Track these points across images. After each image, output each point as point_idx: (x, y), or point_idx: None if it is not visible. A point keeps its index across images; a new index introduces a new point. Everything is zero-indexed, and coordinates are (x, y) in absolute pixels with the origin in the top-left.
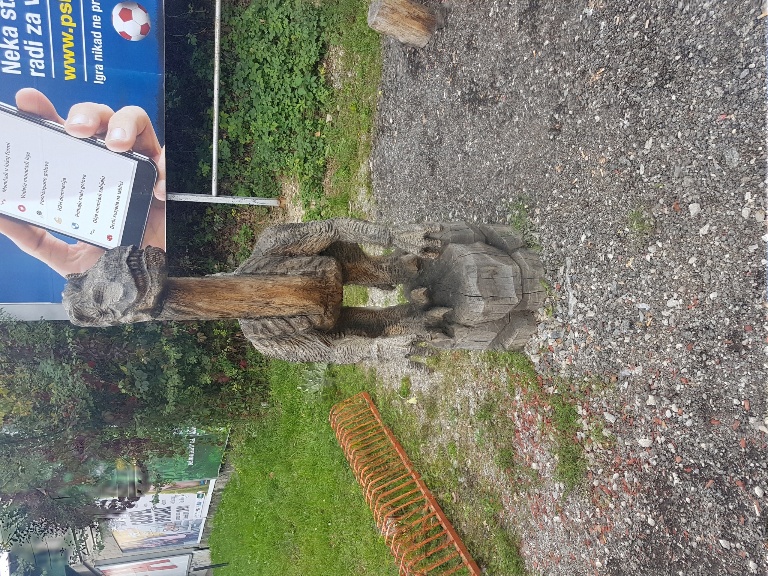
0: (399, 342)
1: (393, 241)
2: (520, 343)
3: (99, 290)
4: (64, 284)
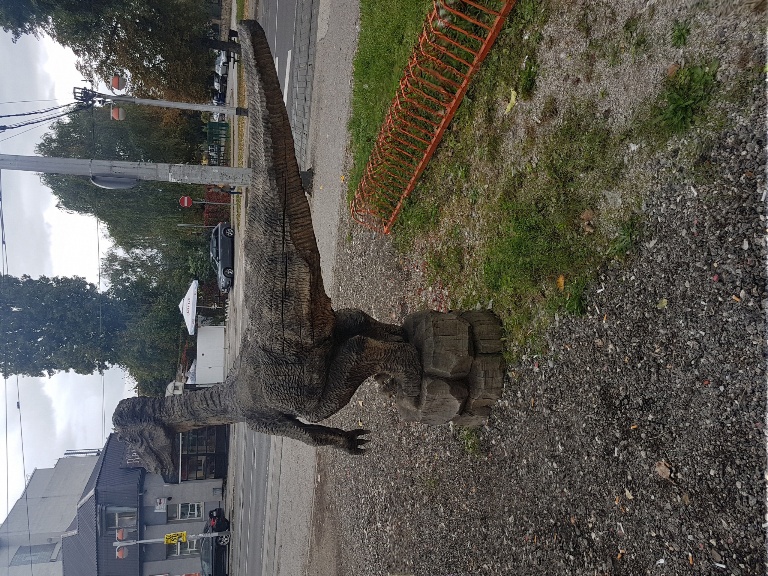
0: None
1: None
2: None
3: None
4: None
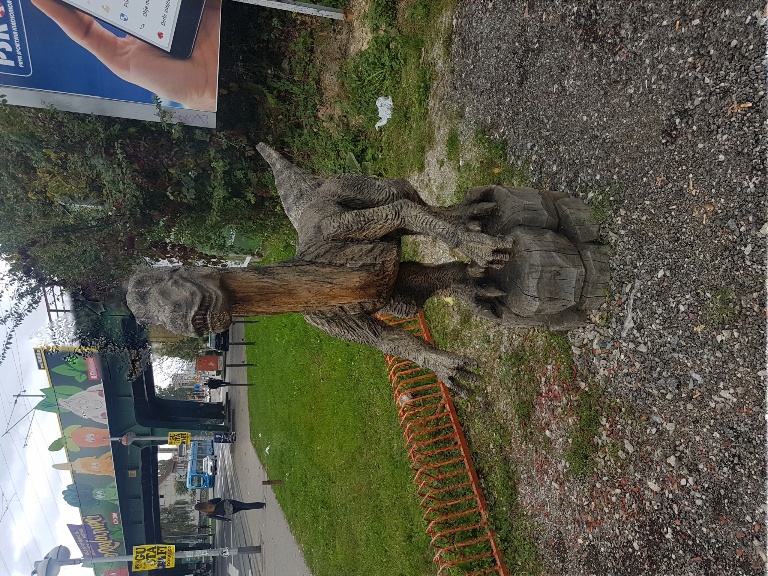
0: (445, 362)
1: (460, 246)
2: (565, 328)
3: (163, 323)
4: (129, 295)
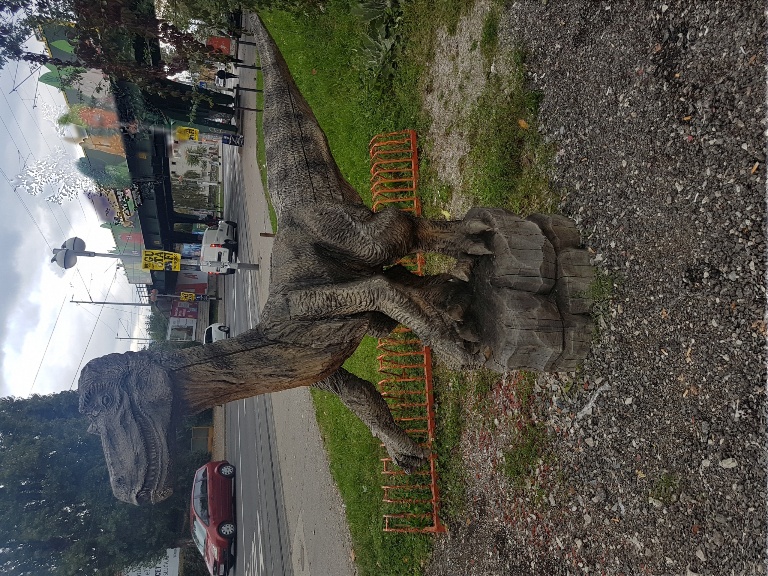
0: (395, 446)
1: None
2: None
3: None
4: (80, 413)
